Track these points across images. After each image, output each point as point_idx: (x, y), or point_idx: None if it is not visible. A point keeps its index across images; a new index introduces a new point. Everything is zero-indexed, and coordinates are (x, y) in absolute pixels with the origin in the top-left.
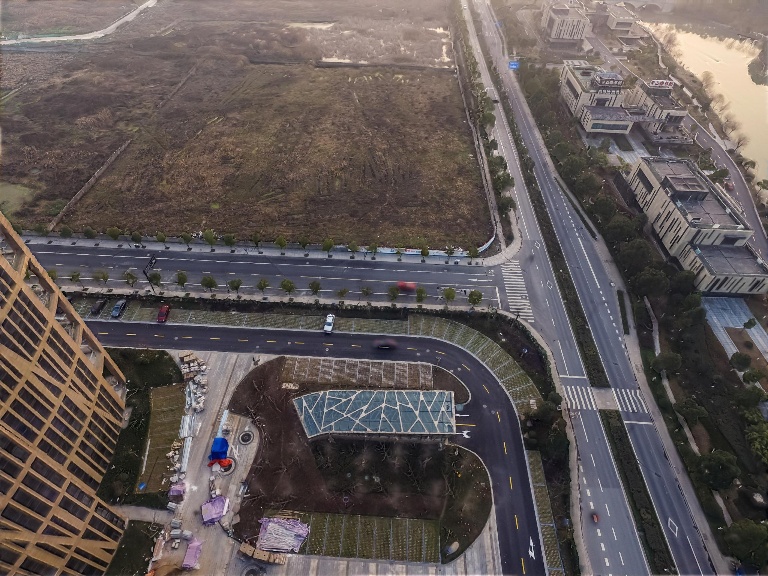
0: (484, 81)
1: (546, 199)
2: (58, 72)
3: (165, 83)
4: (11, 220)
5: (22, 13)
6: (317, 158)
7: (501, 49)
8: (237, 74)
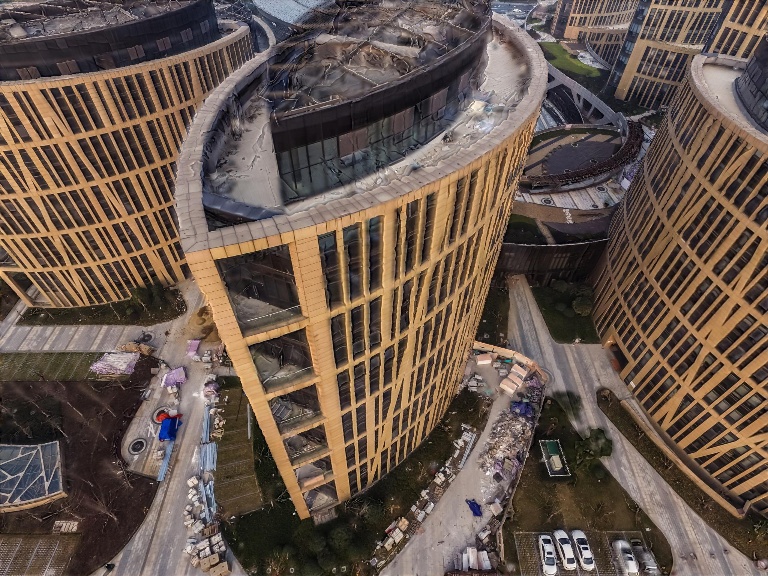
0: None
1: None
2: None
3: None
4: None
5: None
6: None
7: None
8: None
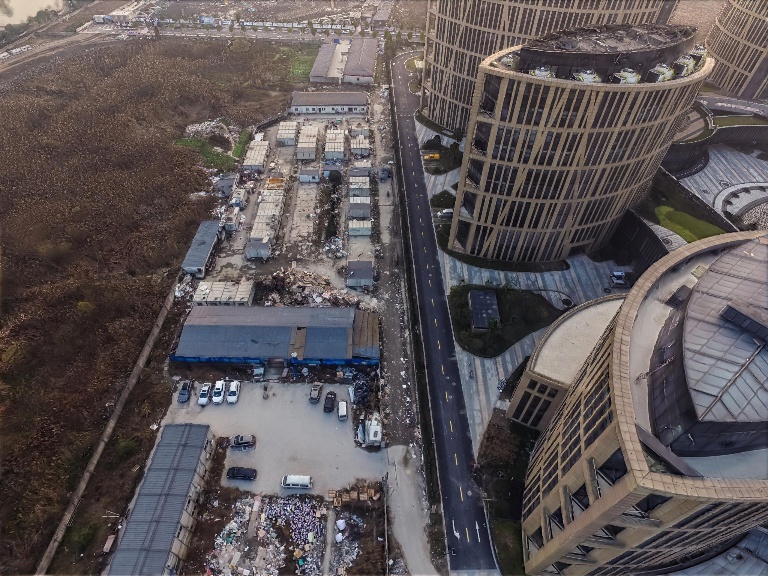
0: None
1: None
2: None
3: None
4: None
5: None
6: (686, 18)
7: None
8: None
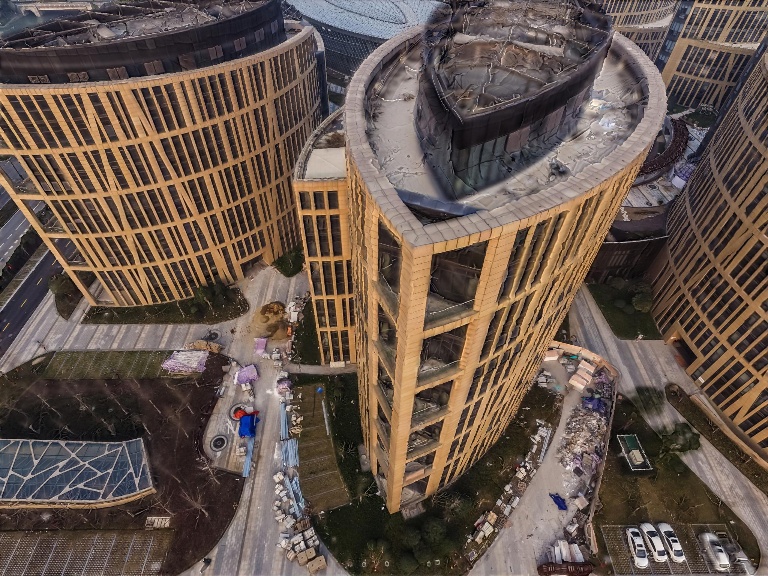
0: None
1: None
2: None
3: None
4: None
5: None
6: None
7: None
8: None
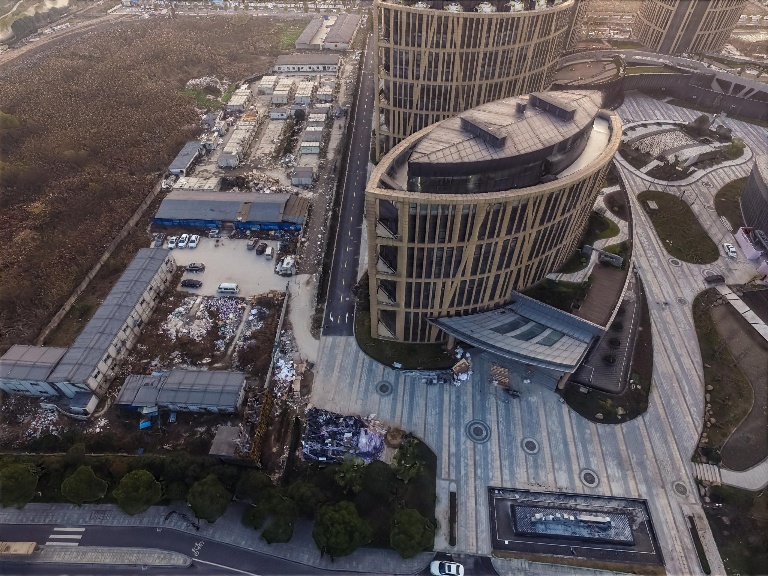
0: None
1: None
2: None
3: None
4: None
5: None
6: None
7: None
8: None
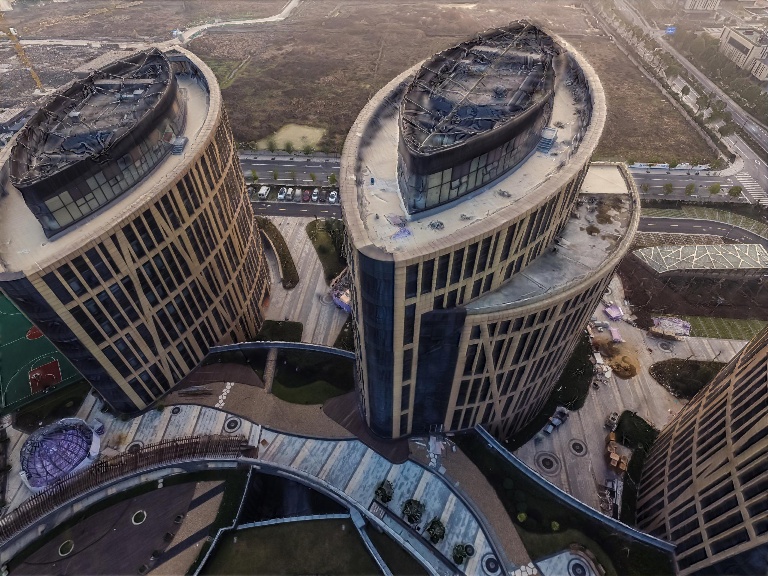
0: (640, 46)
1: (747, 131)
2: (270, 46)
3: (366, 52)
4: (319, 148)
5: (204, 3)
6: None
7: (640, 20)
8: (421, 45)
